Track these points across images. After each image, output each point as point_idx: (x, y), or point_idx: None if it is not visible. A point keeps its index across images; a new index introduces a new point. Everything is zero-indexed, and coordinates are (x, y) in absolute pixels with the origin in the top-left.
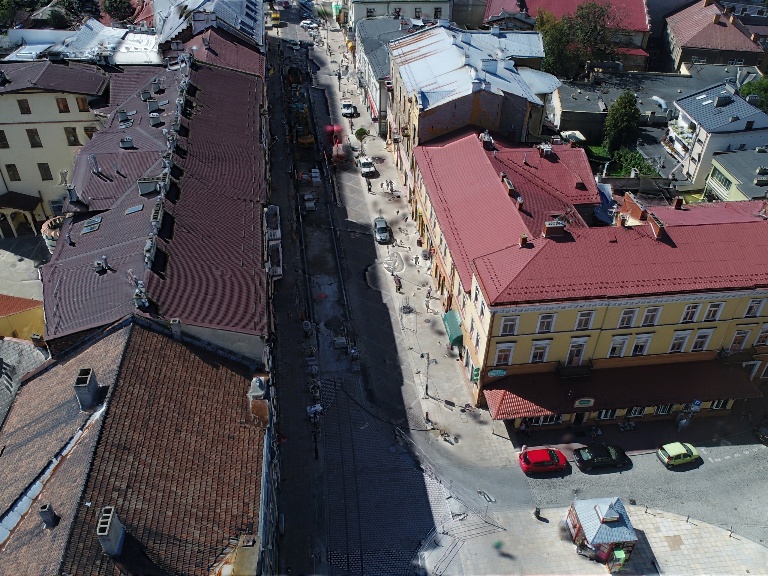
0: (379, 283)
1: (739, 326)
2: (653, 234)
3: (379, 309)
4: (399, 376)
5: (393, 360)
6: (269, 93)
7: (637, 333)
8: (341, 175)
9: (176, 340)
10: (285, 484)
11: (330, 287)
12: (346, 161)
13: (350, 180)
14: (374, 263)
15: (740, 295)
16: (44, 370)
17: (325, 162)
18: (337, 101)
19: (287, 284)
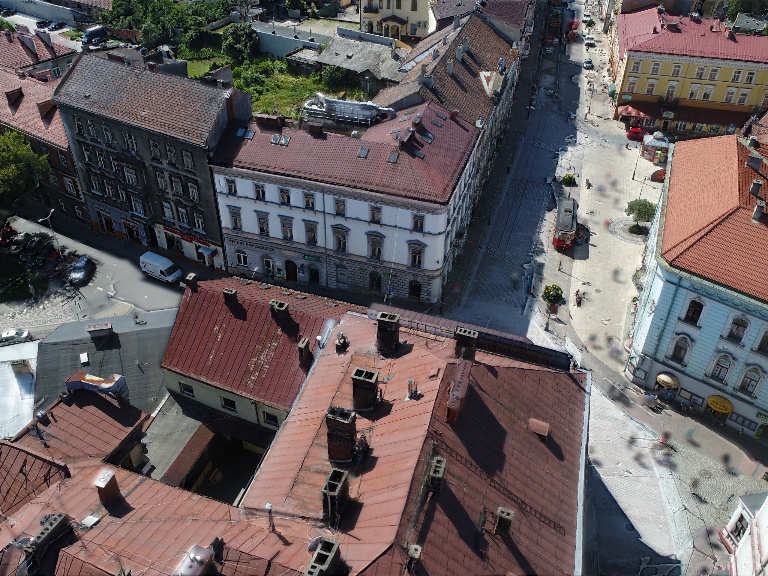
0: (579, 81)
1: (766, 91)
2: (726, 36)
3: (575, 88)
4: (577, 107)
5: (576, 102)
6: (537, 7)
7: (705, 84)
8: (572, 44)
9: (487, 24)
10: (511, 122)
11: (551, 79)
12: (577, 37)
13: (577, 46)
14: (579, 74)
15: (766, 68)
16: (432, 34)
17: (564, 34)
18: (581, 16)
19: (528, 74)
